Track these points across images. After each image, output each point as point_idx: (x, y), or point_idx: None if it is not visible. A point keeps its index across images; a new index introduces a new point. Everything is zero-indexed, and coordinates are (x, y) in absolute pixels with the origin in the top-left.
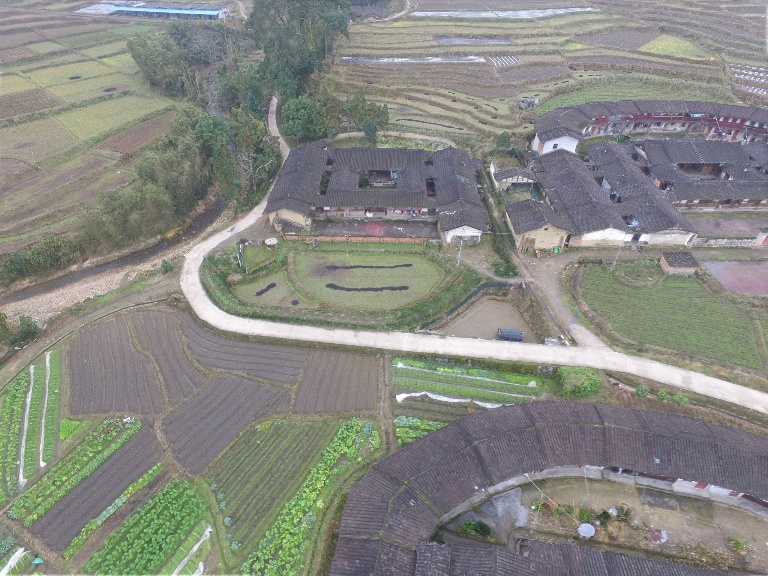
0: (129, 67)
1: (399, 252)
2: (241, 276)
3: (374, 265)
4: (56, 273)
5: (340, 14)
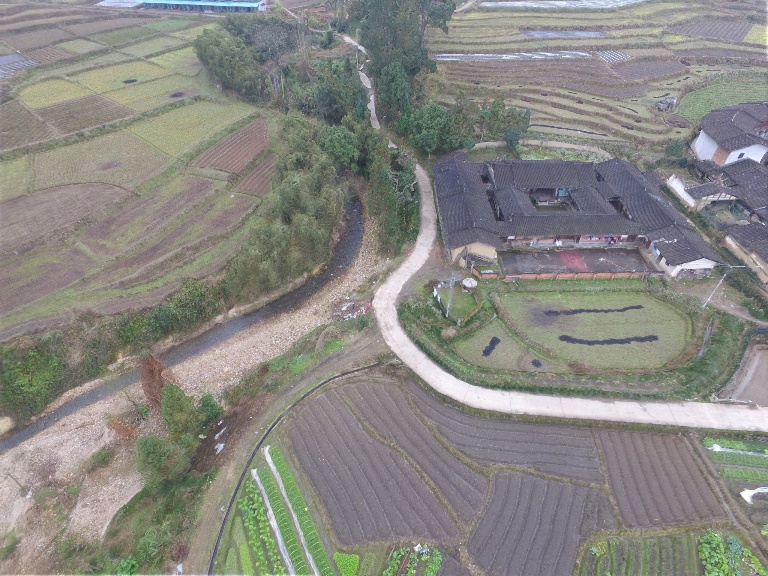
0: (185, 68)
1: (619, 290)
2: (455, 330)
3: (599, 308)
4: (201, 327)
5: (447, 6)
